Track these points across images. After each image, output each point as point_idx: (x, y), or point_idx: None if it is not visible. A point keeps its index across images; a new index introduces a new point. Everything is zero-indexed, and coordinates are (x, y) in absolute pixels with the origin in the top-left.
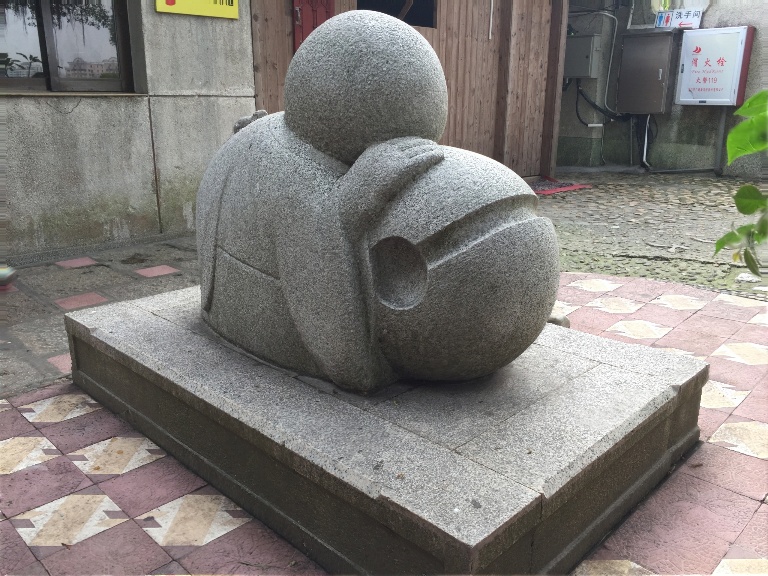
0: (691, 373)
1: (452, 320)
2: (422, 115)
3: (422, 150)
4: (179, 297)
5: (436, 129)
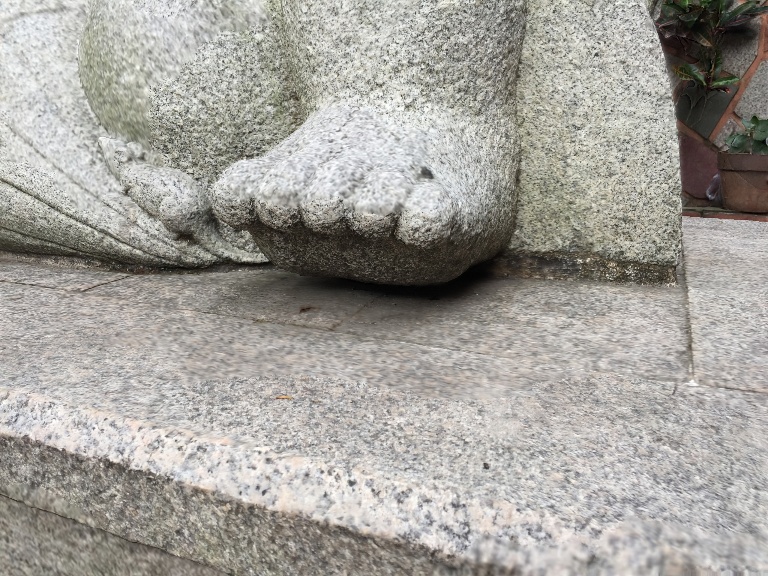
0: None
1: None
2: None
3: None
4: (761, 254)
5: None
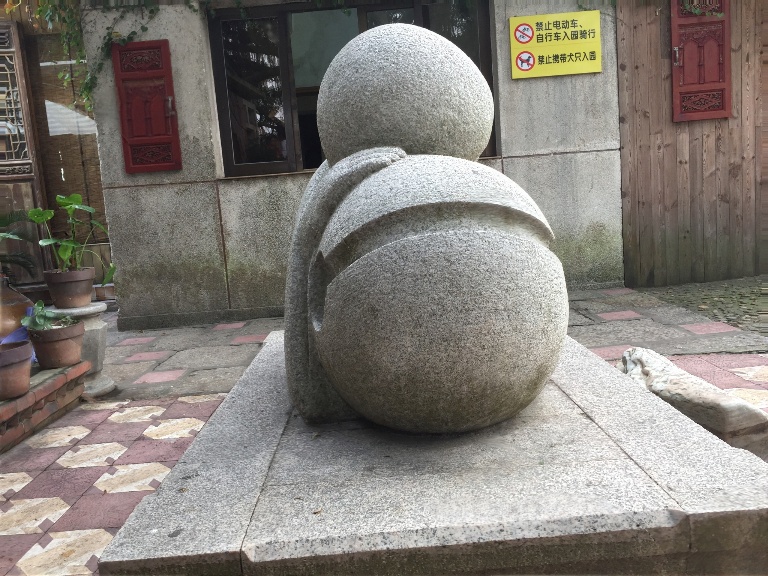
0: (746, 505)
1: (341, 346)
2: (395, 122)
3: (367, 158)
4: None
5: (430, 137)
